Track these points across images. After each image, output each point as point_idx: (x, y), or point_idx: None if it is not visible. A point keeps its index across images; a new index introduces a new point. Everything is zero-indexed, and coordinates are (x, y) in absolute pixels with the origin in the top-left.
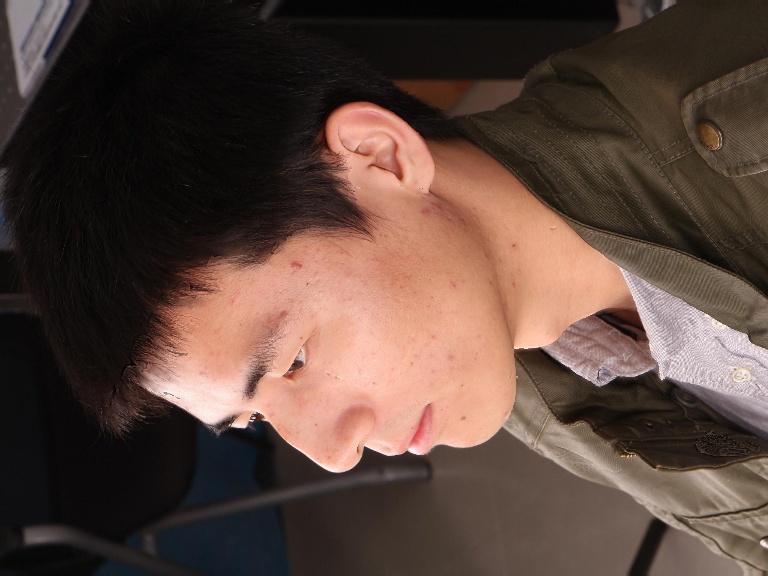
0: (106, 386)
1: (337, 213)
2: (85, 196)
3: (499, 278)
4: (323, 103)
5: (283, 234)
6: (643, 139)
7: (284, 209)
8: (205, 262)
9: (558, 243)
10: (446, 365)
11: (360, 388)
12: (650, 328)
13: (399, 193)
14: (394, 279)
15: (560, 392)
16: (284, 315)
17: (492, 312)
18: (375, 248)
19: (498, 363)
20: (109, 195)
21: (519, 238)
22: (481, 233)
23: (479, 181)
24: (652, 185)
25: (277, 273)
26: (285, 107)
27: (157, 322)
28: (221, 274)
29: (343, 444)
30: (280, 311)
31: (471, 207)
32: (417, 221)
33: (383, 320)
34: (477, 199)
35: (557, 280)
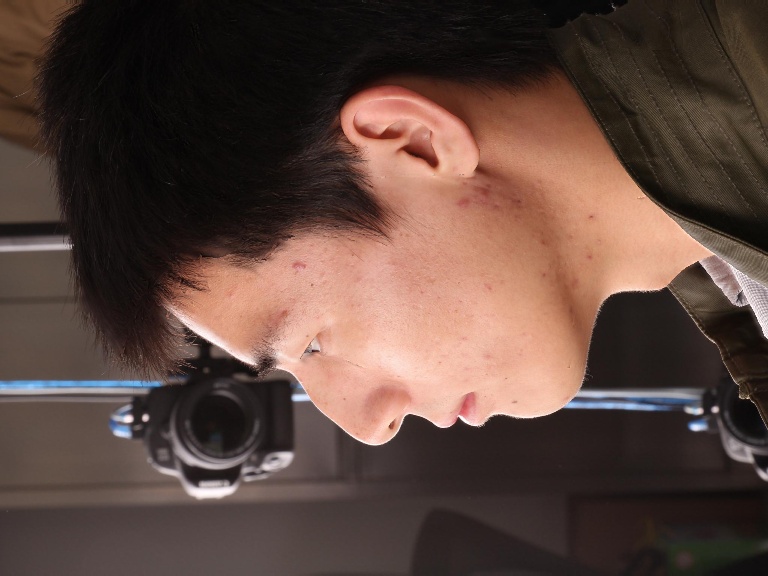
0: (115, 343)
1: (350, 210)
2: (83, 157)
3: (564, 259)
4: (344, 82)
5: (281, 236)
6: (757, 109)
7: (282, 210)
8: (194, 259)
9: (649, 211)
10: (482, 363)
11: (386, 376)
12: (755, 309)
13: (431, 183)
14: (414, 284)
15: (703, 298)
16: (285, 315)
17: (542, 307)
18: (393, 250)
19: (551, 356)
20: (101, 167)
21: (598, 209)
22: (543, 212)
23: (552, 146)
24: (762, 163)
25: (277, 272)
26: (295, 90)
27: (161, 294)
28: (216, 267)
29: (371, 424)
30: (281, 310)
31: (536, 180)
32: (450, 216)
33: (397, 328)
34: (545, 169)
35: (654, 241)
